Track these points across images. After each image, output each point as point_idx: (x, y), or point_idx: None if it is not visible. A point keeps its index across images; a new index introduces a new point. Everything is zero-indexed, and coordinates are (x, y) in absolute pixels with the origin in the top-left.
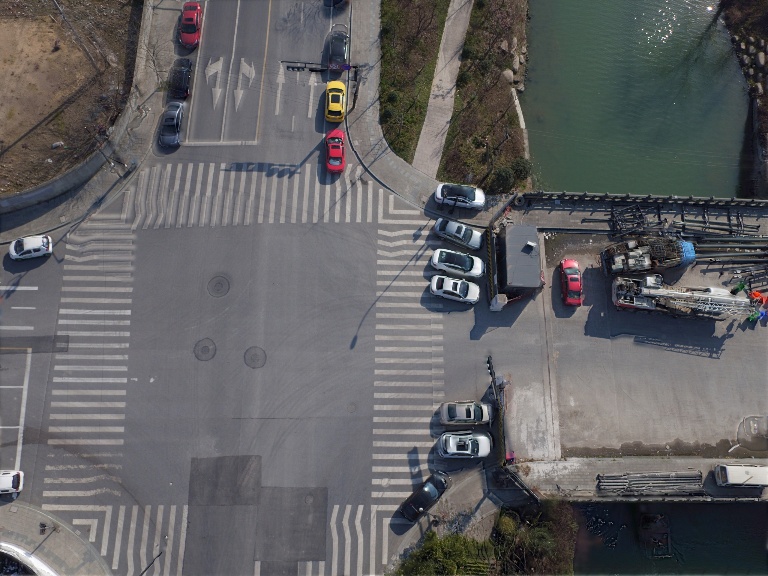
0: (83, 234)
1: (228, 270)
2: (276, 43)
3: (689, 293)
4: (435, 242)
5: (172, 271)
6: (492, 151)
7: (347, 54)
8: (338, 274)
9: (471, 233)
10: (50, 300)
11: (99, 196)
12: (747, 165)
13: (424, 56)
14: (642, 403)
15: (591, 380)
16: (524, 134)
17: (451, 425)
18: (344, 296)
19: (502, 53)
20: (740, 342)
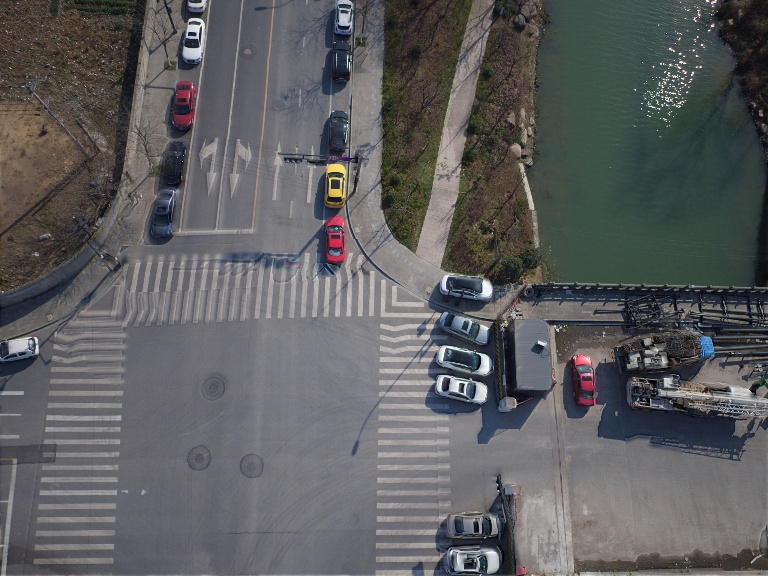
0: (71, 333)
1: (223, 370)
2: (273, 122)
3: (708, 395)
4: (440, 337)
5: (164, 372)
6: (500, 236)
7: (347, 138)
8: (339, 373)
9: (478, 328)
10: (36, 406)
11: (88, 291)
12: (766, 243)
13: (428, 133)
14: (659, 511)
15: (605, 486)
16: (533, 216)
17: (458, 538)
18: (345, 397)
19: (509, 127)
20: (762, 442)
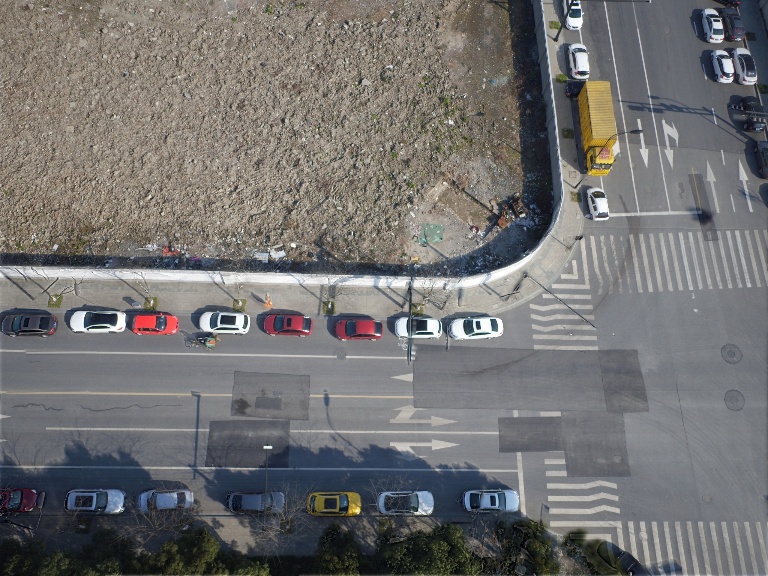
0: None
1: None
2: None
3: None
4: None
5: None
6: None
7: None
8: None
9: None
10: (744, 222)
11: None
12: None
13: None
14: None
15: None
16: None
17: None
18: None
19: None
20: None
